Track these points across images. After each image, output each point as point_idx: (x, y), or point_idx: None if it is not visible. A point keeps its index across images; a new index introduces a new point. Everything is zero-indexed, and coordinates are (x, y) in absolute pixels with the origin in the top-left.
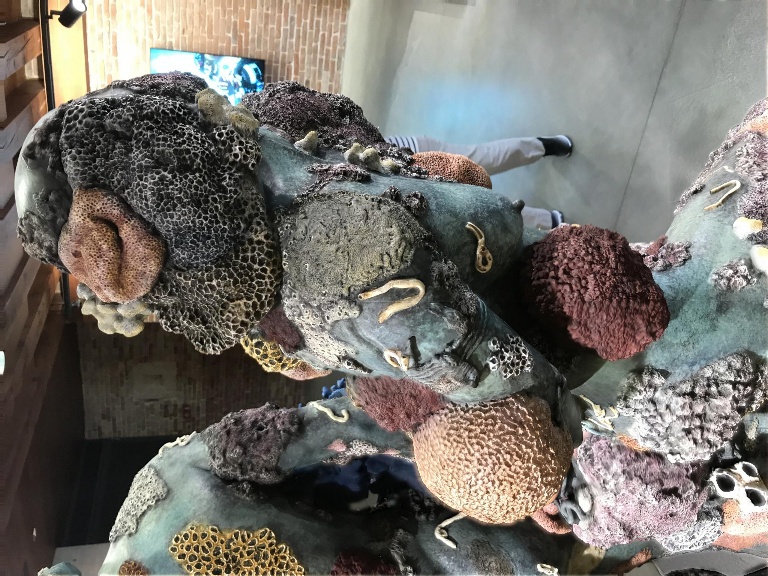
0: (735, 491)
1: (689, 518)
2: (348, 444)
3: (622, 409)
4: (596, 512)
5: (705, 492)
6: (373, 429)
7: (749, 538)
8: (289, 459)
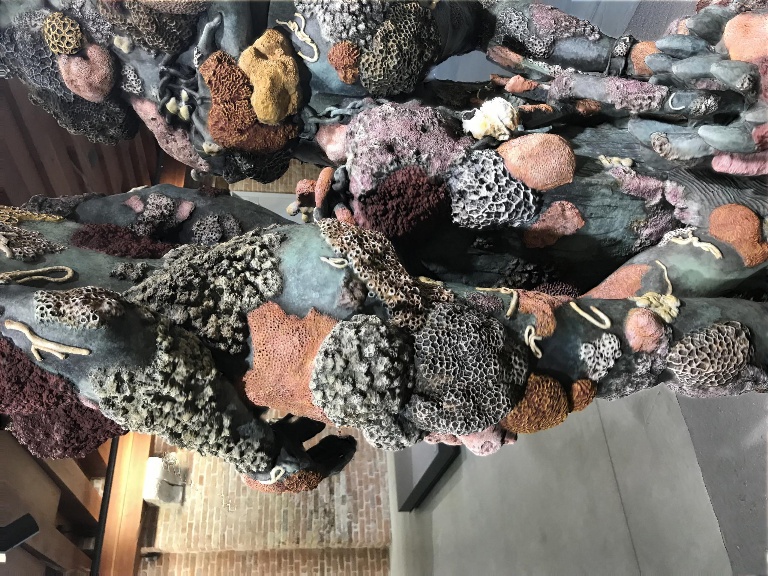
0: (479, 113)
1: (455, 148)
2: (145, 202)
3: (299, 5)
4: (358, 155)
5: (467, 139)
6: (168, 188)
7: (629, 277)
8: (87, 207)
